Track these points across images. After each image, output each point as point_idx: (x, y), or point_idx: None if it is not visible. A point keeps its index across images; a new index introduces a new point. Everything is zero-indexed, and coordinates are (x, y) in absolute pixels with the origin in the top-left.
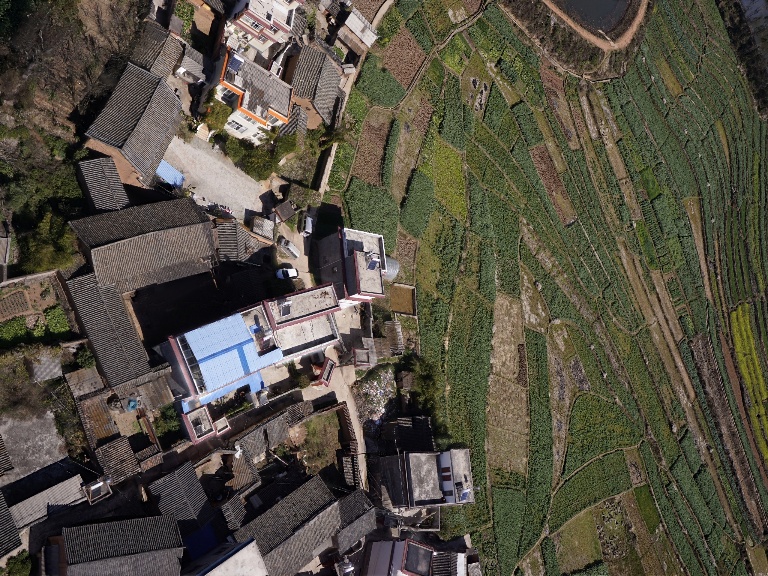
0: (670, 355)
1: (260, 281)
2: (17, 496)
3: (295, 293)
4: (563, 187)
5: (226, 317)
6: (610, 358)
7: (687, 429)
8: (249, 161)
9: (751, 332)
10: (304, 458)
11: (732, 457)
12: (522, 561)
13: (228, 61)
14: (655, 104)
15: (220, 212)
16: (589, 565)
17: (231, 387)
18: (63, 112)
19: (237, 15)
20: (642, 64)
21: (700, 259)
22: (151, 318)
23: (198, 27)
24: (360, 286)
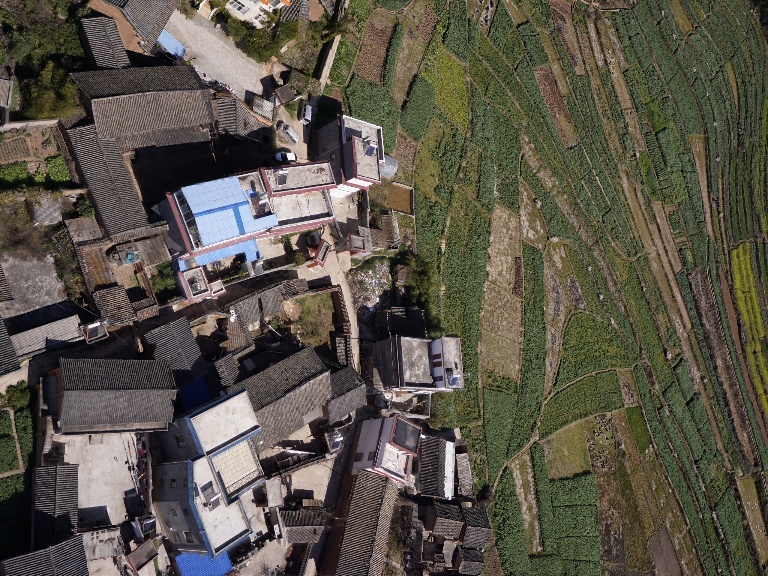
0: (668, 285)
1: (258, 157)
2: (17, 330)
3: (292, 165)
4: (567, 110)
5: (223, 178)
6: (607, 281)
7: (682, 358)
8: (250, 40)
9: (751, 271)
10: (298, 333)
11: (726, 389)
12: (511, 461)
13: None
14: (664, 39)
15: (220, 87)
16: (577, 474)
17: (227, 253)
18: None
19: None
20: None
21: (703, 196)
22: (150, 181)
23: None
24: (357, 170)
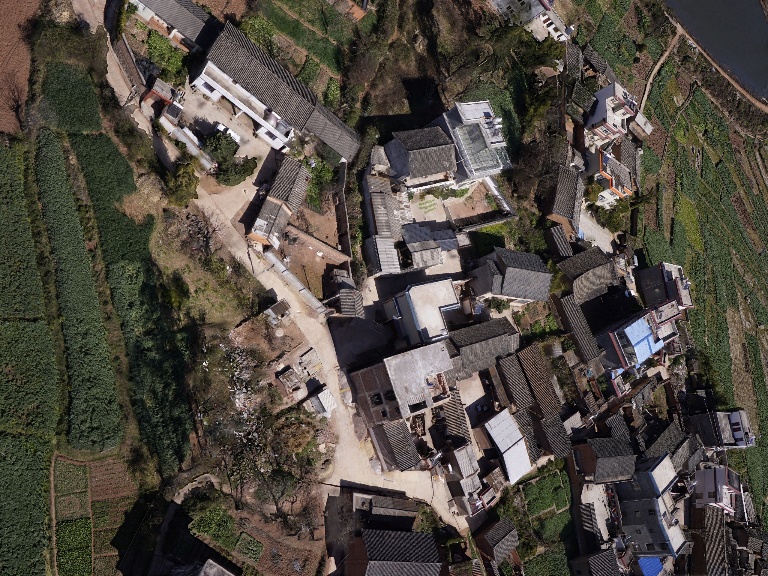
0: None
1: None
2: None
3: (661, 305)
4: (753, 224)
5: (638, 320)
6: None
7: None
8: (612, 221)
9: None
10: None
11: None
12: (765, 498)
13: (602, 158)
14: None
15: None
16: None
17: None
18: (531, 197)
19: (595, 125)
20: None
21: None
22: None
23: None
24: (682, 301)
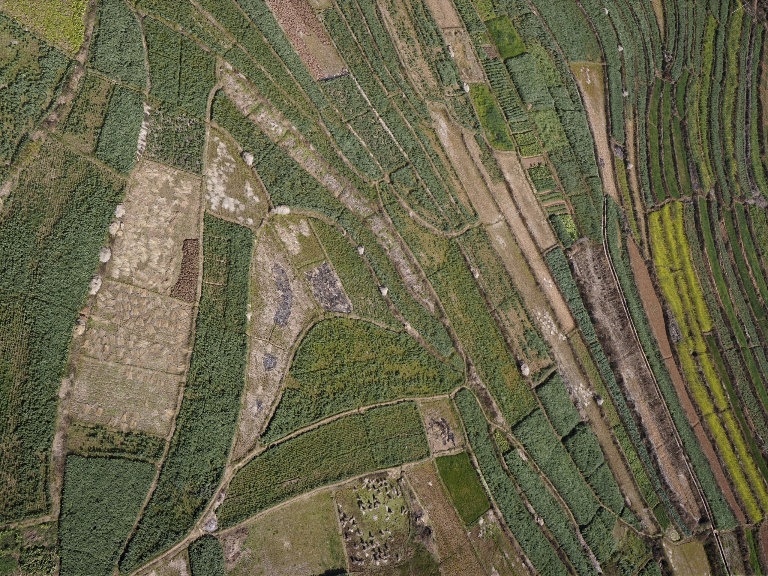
0: (527, 267)
1: None
2: None
3: None
4: (322, 28)
5: None
6: (400, 268)
7: (554, 372)
8: None
9: (685, 240)
10: None
11: (642, 412)
12: None
13: None
14: None
15: None
16: None
17: None
18: None
19: None
20: None
21: (598, 142)
22: None
23: None
24: None
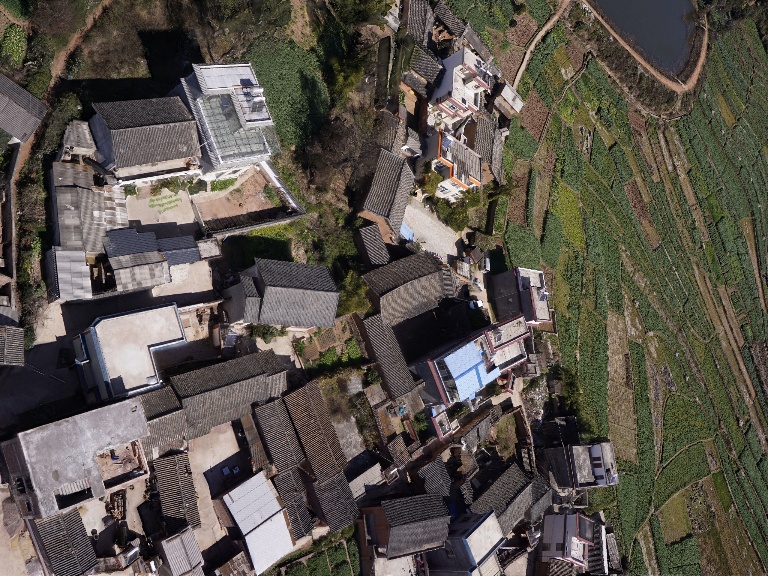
0: (735, 359)
1: (466, 313)
2: None
3: (502, 324)
4: (649, 216)
5: (465, 345)
6: (690, 363)
7: (750, 423)
8: (453, 217)
9: None
10: (498, 450)
11: None
12: (638, 533)
13: (442, 140)
14: (715, 135)
15: (437, 259)
16: (683, 538)
17: None
18: (340, 189)
19: (439, 100)
20: (704, 100)
21: (755, 273)
22: (400, 344)
23: (407, 109)
24: (536, 315)
